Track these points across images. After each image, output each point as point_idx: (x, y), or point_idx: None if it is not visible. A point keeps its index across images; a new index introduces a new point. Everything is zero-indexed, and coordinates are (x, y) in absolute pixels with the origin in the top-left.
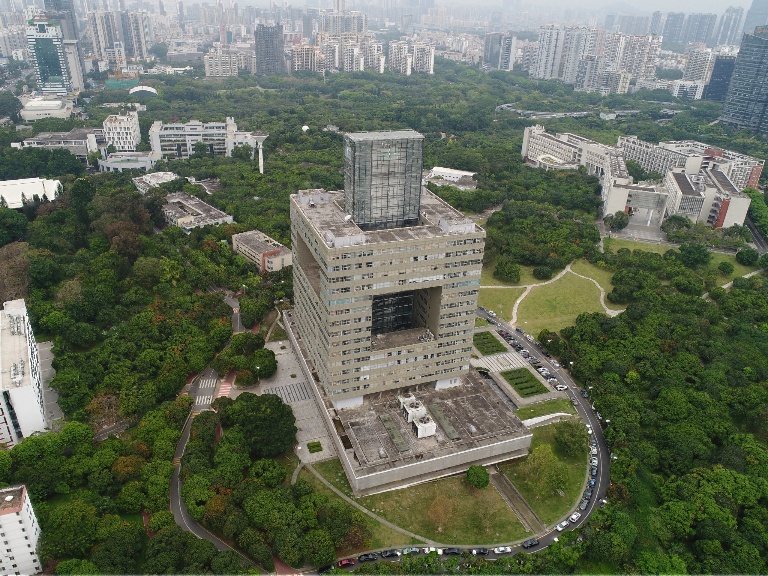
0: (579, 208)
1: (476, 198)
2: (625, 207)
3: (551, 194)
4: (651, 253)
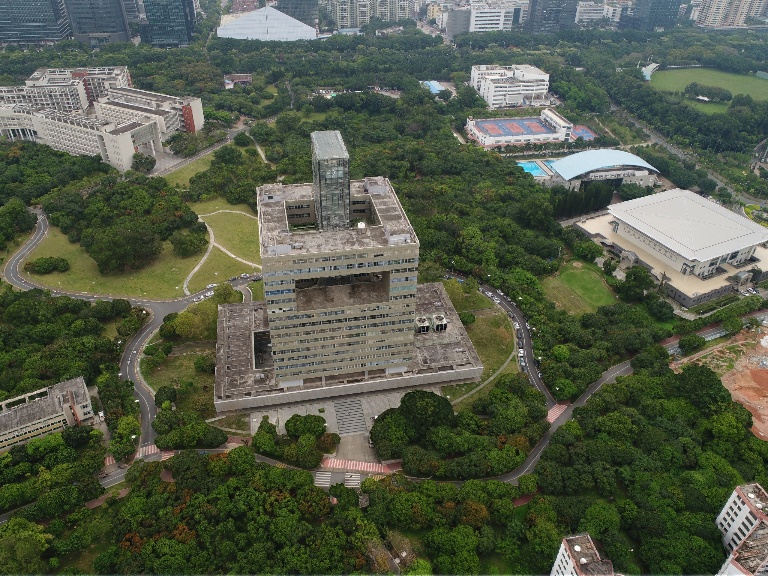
0: (91, 171)
1: (13, 217)
2: (134, 148)
3: (59, 172)
4: (209, 170)
